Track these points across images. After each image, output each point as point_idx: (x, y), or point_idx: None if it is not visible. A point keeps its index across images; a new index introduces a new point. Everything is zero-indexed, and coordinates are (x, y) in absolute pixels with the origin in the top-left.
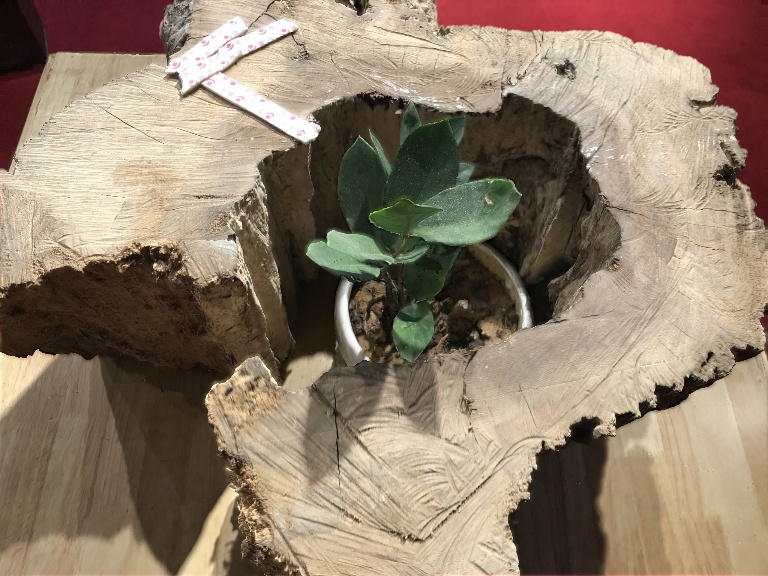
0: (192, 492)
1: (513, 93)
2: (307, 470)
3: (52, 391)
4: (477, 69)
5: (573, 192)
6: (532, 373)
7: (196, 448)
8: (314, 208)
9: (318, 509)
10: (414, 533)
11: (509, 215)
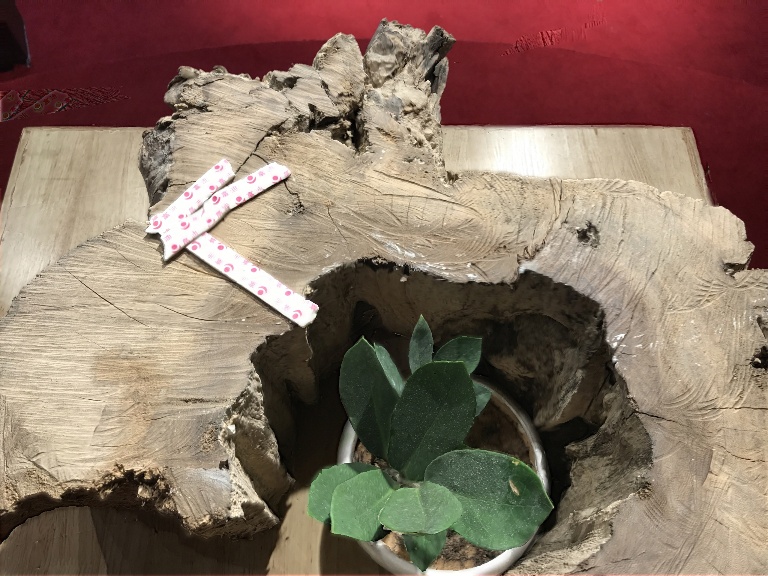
0: None
1: (531, 270)
2: None
3: (39, 535)
4: (489, 226)
5: (595, 365)
6: None
7: None
8: (312, 359)
9: None
10: None
11: (539, 524)
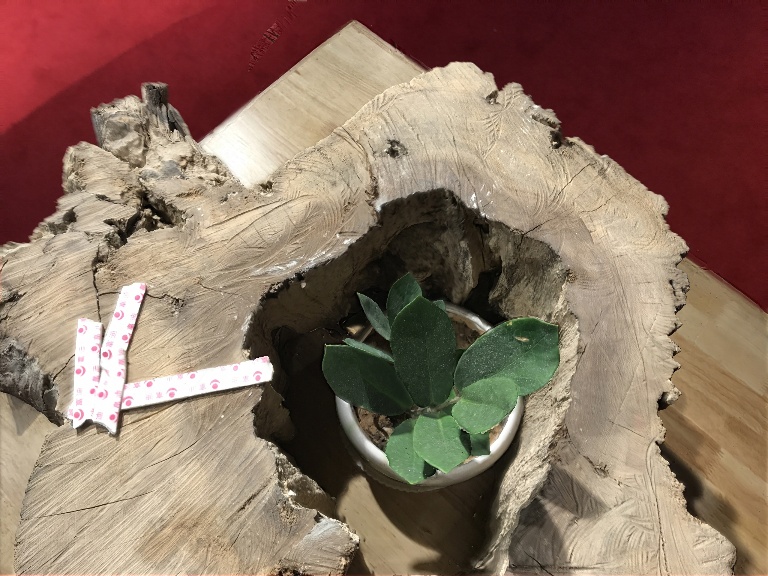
0: None
1: (384, 203)
2: None
3: None
4: (326, 198)
5: (468, 230)
6: (606, 404)
7: None
8: None
9: None
10: None
11: None
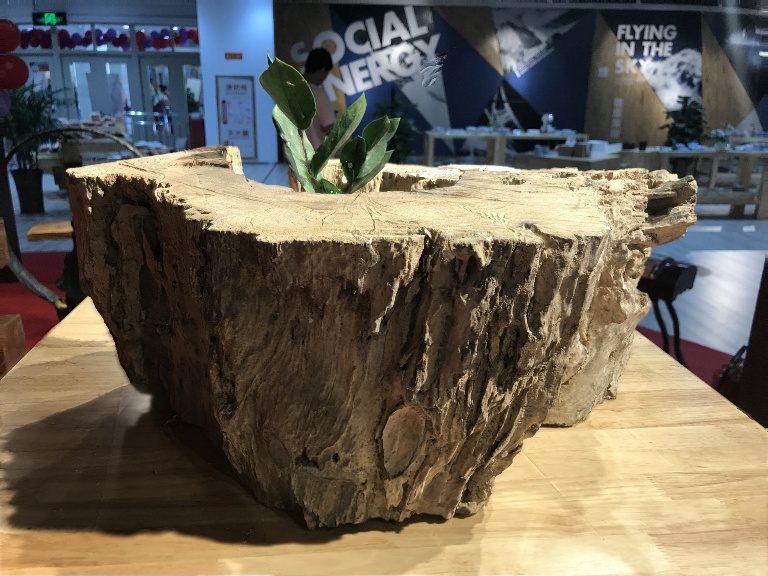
0: None
1: None
2: None
3: None
4: None
5: None
6: None
7: None
8: None
9: None
10: None
11: None
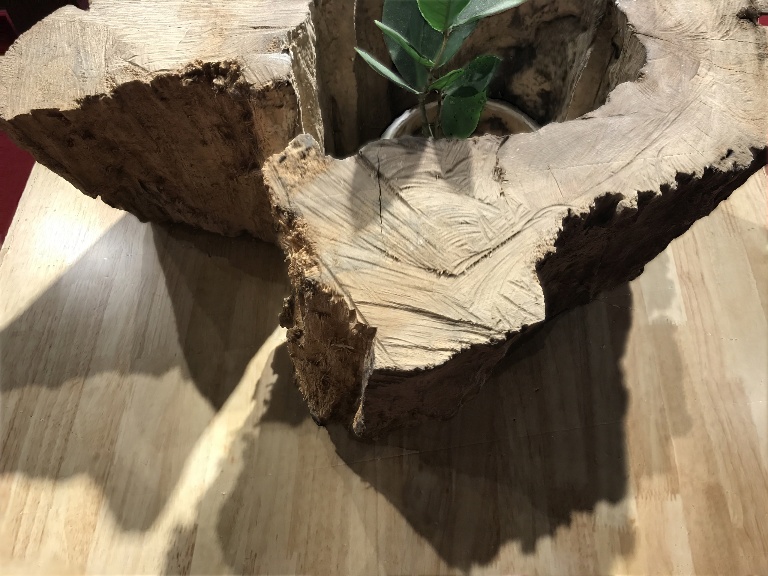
0: (236, 341)
1: None
2: (352, 220)
3: (108, 254)
4: None
5: (602, 41)
6: (560, 156)
7: (240, 305)
8: (357, 73)
9: (362, 251)
10: (449, 269)
11: None
